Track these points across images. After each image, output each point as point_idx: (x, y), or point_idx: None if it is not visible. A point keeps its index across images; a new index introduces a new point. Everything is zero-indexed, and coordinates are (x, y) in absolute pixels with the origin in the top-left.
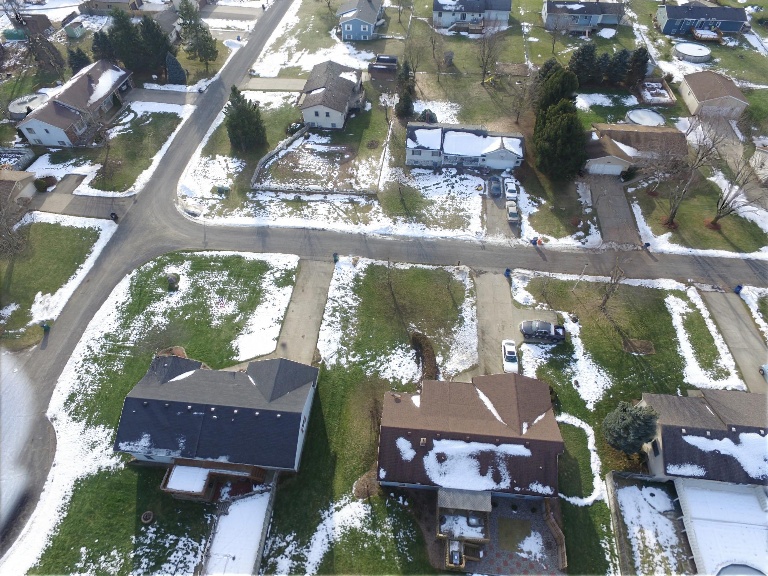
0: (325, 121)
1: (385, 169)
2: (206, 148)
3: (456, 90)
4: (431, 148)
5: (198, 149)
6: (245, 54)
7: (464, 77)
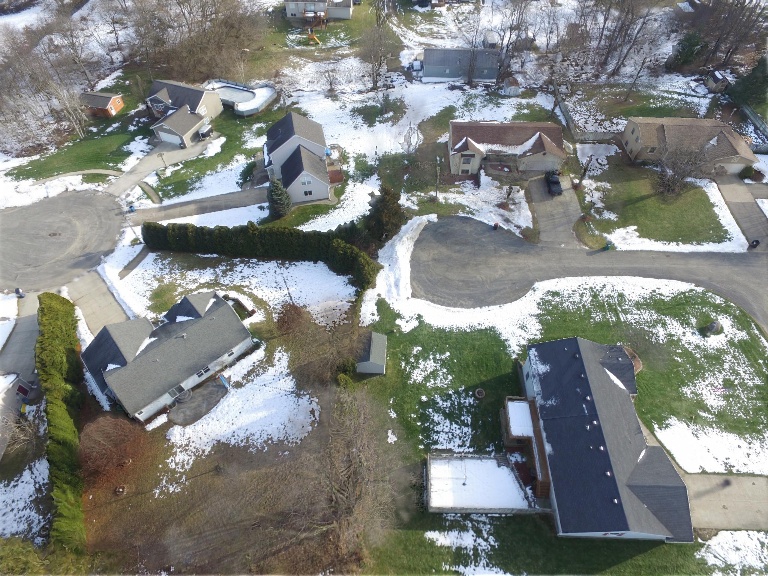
0: None
1: None
2: None
3: None
4: None
5: None
6: None
7: None
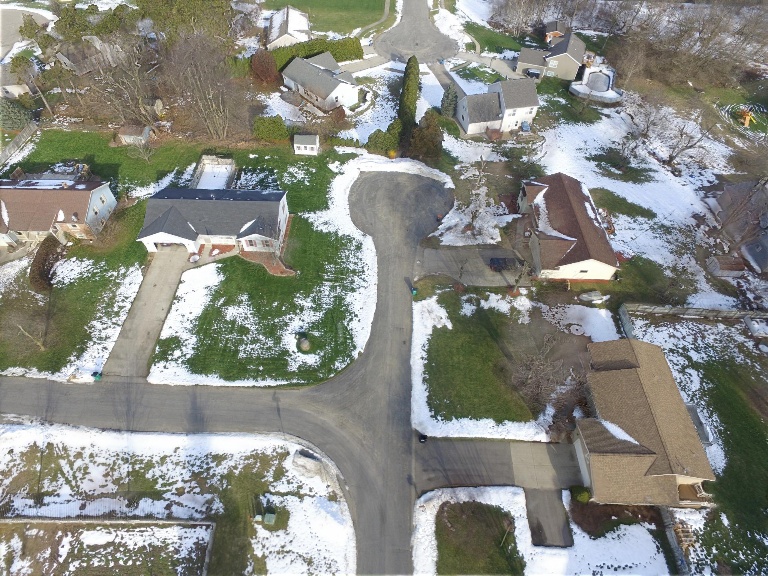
0: None
1: None
2: None
3: None
4: None
5: None
6: None
7: None
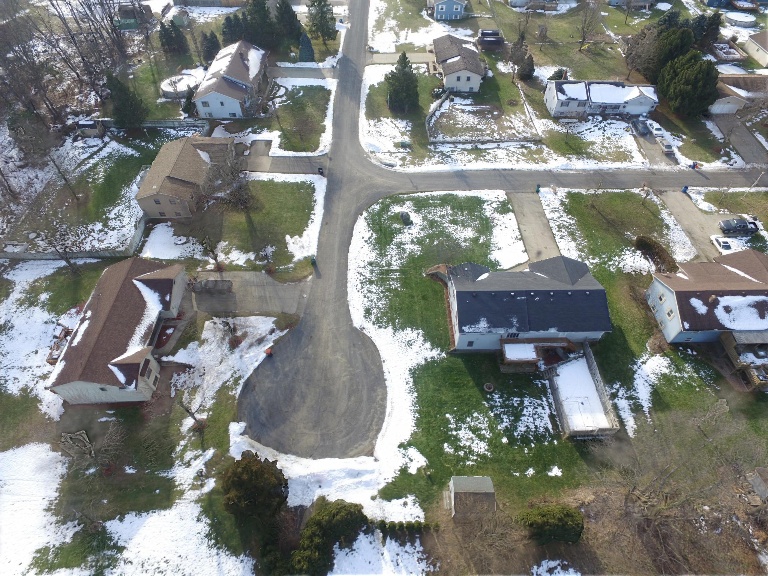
0: (464, 85)
1: (536, 121)
2: (368, 113)
3: (560, 57)
4: (579, 99)
5: (361, 114)
6: (355, 34)
7: (561, 46)
